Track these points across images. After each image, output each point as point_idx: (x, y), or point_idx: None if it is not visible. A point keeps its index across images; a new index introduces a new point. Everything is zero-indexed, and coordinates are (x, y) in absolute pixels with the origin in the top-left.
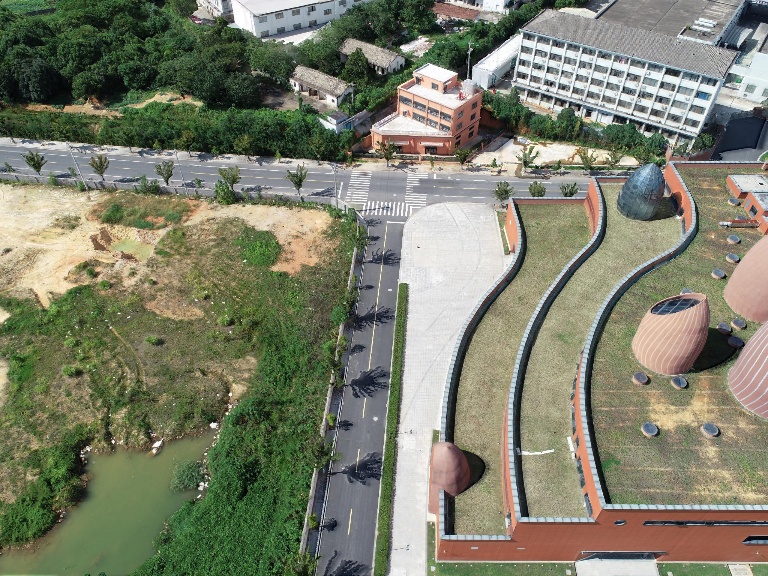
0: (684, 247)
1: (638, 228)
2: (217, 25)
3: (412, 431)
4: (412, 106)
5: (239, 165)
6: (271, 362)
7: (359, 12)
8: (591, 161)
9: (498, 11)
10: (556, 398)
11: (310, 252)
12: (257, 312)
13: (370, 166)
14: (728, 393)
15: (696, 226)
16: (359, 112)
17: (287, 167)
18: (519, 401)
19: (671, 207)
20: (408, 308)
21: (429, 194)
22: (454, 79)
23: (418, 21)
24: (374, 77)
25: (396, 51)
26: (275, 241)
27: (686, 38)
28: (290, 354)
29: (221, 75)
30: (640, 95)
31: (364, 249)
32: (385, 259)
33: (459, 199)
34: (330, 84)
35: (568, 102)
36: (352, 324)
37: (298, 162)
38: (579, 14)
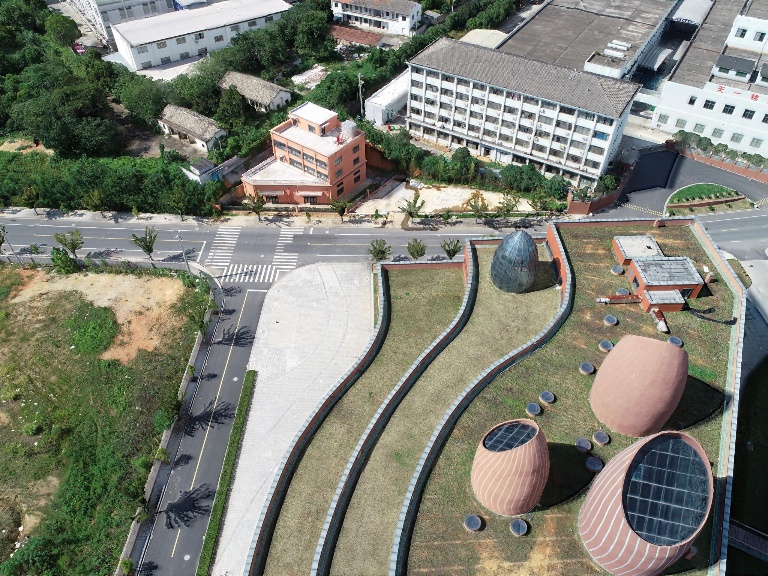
0: (553, 332)
1: (511, 303)
2: (89, 58)
3: (227, 574)
4: (287, 151)
5: (91, 223)
6: (74, 485)
7: (244, 41)
8: (482, 210)
9: (404, 34)
10: (377, 546)
11: (151, 333)
12: (73, 415)
13: (240, 220)
14: (576, 539)
15: (571, 303)
16: (228, 159)
17: (146, 224)
18: (331, 553)
19: (552, 274)
20: (252, 403)
21: (301, 253)
22: (334, 120)
23: (312, 49)
24: (253, 116)
25: (286, 83)
26: (112, 320)
27: (594, 65)
28: (100, 472)
29: (72, 121)
30: (537, 134)
31: (214, 326)
32: (237, 339)
33: (334, 258)
34: (200, 127)
35: (465, 140)
36: (182, 427)
37: (159, 218)
38: (489, 37)
